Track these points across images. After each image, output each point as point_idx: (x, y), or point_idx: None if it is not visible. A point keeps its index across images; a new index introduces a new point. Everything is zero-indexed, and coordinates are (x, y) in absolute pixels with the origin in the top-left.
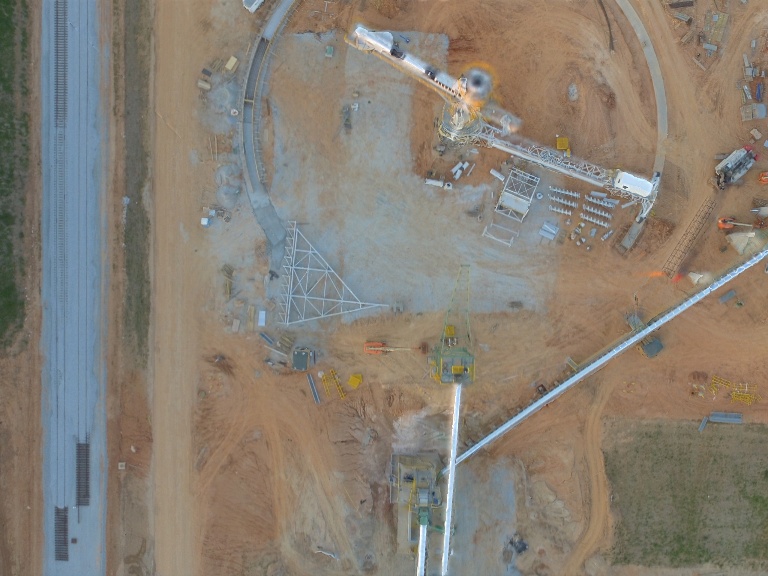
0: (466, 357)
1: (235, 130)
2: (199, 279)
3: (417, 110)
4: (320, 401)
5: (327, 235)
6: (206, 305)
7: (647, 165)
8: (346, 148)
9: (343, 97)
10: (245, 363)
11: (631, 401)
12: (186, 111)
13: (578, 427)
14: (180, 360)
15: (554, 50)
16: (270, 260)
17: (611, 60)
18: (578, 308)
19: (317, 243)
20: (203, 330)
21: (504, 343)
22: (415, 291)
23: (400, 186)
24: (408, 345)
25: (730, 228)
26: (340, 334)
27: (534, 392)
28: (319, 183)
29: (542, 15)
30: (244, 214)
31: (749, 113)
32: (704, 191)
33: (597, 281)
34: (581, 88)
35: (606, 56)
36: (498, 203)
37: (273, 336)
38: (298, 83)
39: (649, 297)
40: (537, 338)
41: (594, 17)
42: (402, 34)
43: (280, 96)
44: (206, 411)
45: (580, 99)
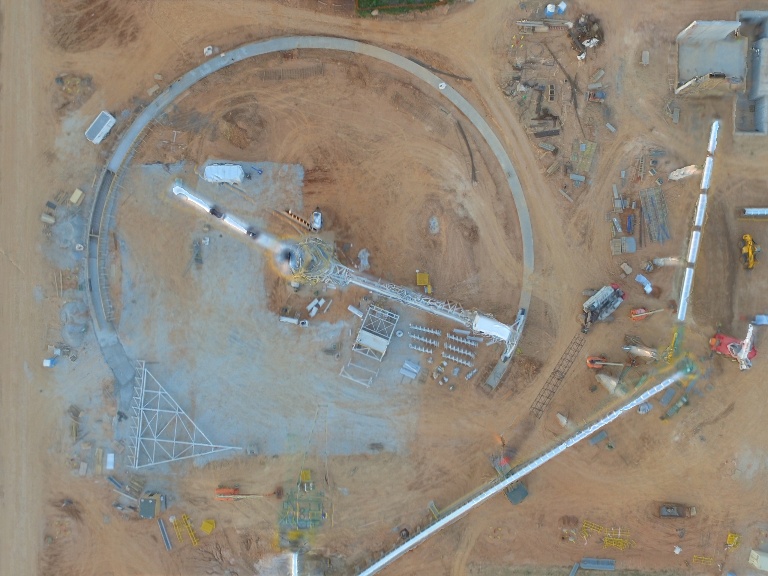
0: (324, 502)
1: (81, 265)
2: (44, 421)
3: (271, 244)
4: (172, 547)
5: (178, 375)
6: (52, 447)
7: (513, 301)
8: (197, 284)
9: (193, 231)
10: (93, 507)
11: (498, 547)
12: (29, 246)
13: (443, 573)
14: (25, 505)
15: (414, 181)
16: (118, 401)
17: (473, 192)
18: (442, 450)
19: (167, 383)
20: (49, 473)
21: (364, 487)
22: (270, 433)
23: (254, 323)
24: (262, 490)
25: (599, 368)
26: (192, 478)
27: (397, 536)
28: (169, 320)
29: (401, 145)
30: (91, 353)
31: (618, 247)
32: (573, 328)
33: (461, 421)
34: (442, 221)
35: (468, 187)
36: (355, 342)
37: (122, 480)
38: (146, 216)
39: (516, 438)
40: (398, 482)
41: (455, 147)
42: (254, 165)
43: (128, 230)
44: (53, 557)
45: (441, 233)
